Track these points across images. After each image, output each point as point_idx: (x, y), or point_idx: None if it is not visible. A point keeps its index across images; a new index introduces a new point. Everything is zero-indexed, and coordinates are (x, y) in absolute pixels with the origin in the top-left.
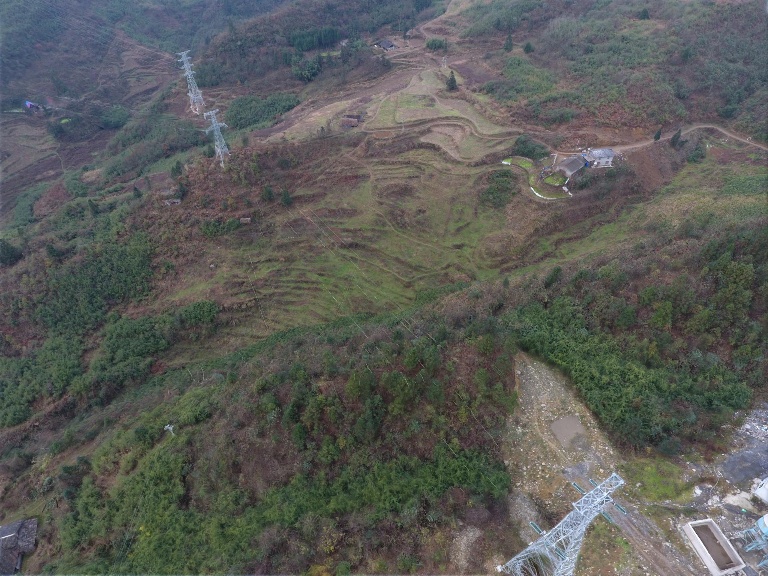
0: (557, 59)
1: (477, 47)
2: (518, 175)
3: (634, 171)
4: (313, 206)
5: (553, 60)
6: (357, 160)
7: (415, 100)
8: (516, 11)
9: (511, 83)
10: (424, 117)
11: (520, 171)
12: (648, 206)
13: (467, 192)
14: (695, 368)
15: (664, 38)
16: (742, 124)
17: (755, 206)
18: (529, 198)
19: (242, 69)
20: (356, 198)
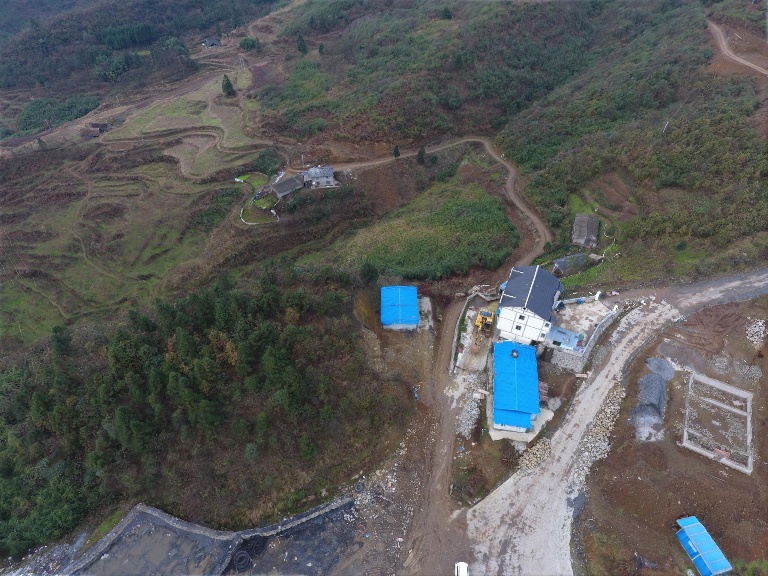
0: (336, 63)
1: (290, 47)
2: (244, 194)
3: (362, 192)
4: (9, 228)
5: (334, 64)
6: (79, 175)
7: (185, 106)
8: (334, 8)
9: (280, 89)
10: (176, 126)
11: (249, 190)
12: (361, 233)
13: (179, 214)
14: (40, 480)
15: (447, 41)
16: (498, 139)
17: (422, 240)
18: (230, 223)
19: (44, 69)
20: (58, 219)
